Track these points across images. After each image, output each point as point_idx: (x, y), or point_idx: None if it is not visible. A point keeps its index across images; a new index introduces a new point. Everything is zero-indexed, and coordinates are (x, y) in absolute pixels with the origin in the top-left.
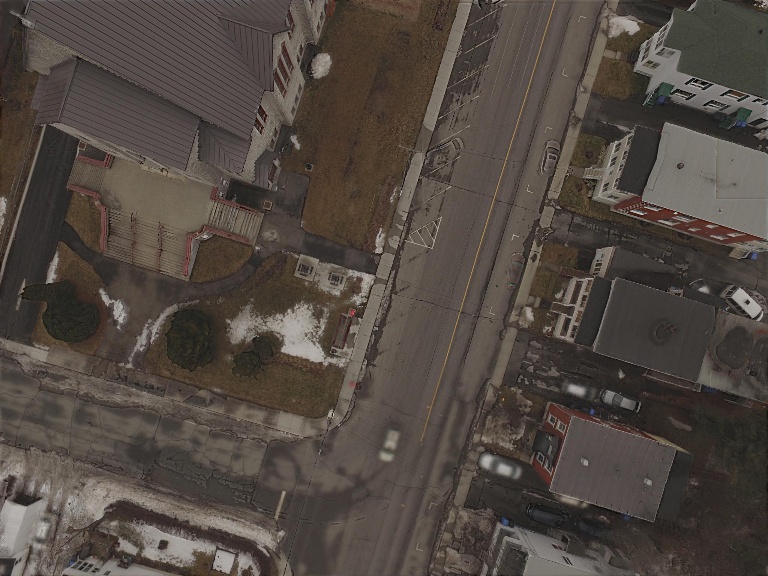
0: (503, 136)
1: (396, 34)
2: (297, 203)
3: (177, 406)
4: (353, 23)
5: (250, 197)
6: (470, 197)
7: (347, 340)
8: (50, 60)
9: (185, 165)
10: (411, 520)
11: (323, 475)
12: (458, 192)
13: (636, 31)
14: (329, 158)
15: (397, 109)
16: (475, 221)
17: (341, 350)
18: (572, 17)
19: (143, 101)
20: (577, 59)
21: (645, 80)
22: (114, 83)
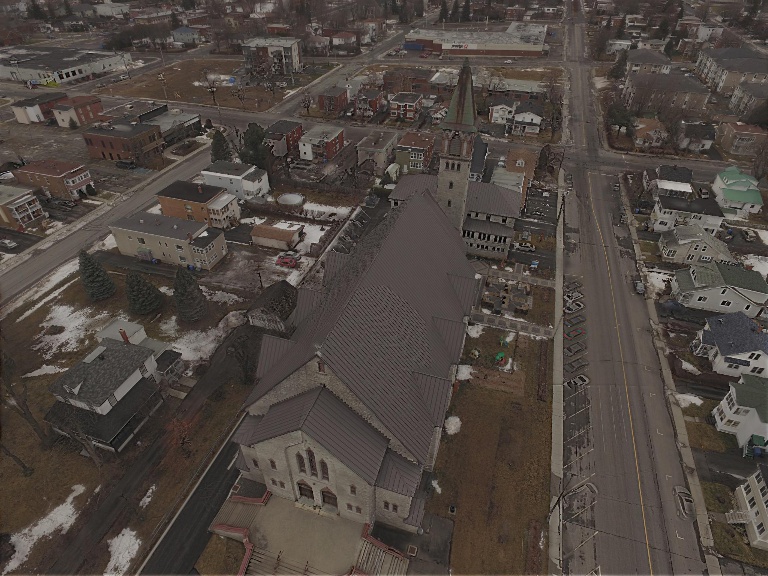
0: (630, 483)
1: (510, 404)
2: (443, 548)
3: None
4: (474, 397)
5: (394, 541)
6: (622, 543)
7: None
8: (284, 395)
9: (374, 481)
10: None
11: None
12: (607, 538)
13: (701, 403)
14: (470, 501)
15: (525, 459)
16: (638, 571)
17: None
18: (644, 394)
19: (354, 422)
20: (664, 422)
21: (732, 437)
22: (339, 406)
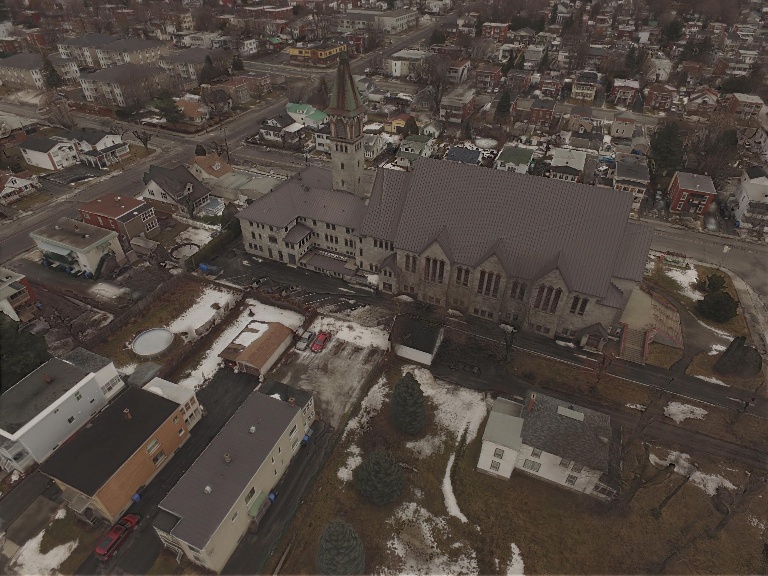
0: None
1: None
2: None
3: (765, 329)
4: None
5: None
6: None
7: (677, 262)
8: None
9: None
10: (761, 251)
11: (761, 276)
12: None
13: None
14: None
15: None
16: None
17: (684, 264)
18: None
19: None
20: None
21: None
22: None
